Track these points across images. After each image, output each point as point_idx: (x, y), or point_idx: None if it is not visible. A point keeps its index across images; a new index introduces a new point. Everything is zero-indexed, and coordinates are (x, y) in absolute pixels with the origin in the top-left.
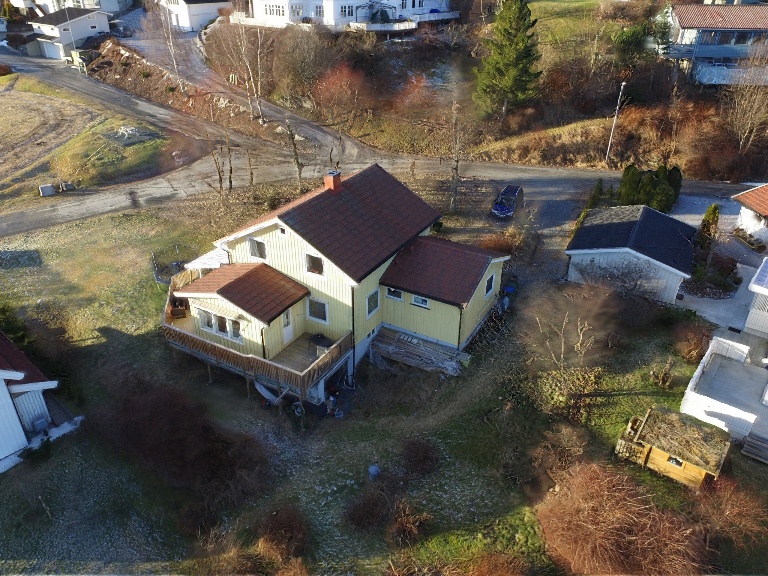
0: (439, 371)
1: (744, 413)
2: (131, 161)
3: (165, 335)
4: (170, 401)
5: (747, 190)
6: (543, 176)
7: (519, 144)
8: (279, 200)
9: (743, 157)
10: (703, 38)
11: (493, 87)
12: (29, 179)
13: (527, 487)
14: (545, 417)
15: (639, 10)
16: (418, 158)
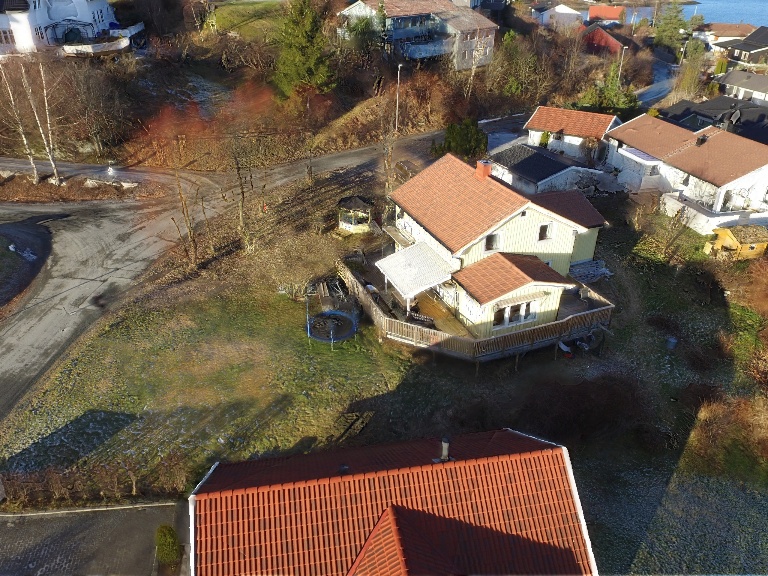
0: (604, 277)
1: (735, 216)
2: None
3: (473, 353)
4: (555, 386)
5: (528, 121)
6: (381, 152)
7: (336, 133)
8: (239, 242)
9: (470, 105)
10: (395, 24)
11: (302, 87)
12: None
13: (715, 303)
14: (673, 268)
15: (316, 7)
16: (271, 168)
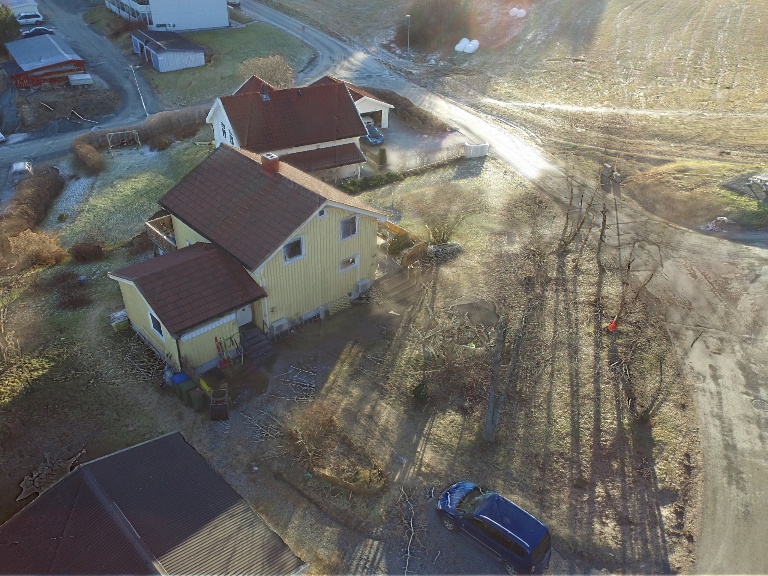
0: None
1: None
2: (682, 195)
3: None
4: None
5: None
6: None
7: None
8: (570, 284)
9: None
10: None
11: None
12: (633, 161)
13: None
14: None
15: None
16: None
